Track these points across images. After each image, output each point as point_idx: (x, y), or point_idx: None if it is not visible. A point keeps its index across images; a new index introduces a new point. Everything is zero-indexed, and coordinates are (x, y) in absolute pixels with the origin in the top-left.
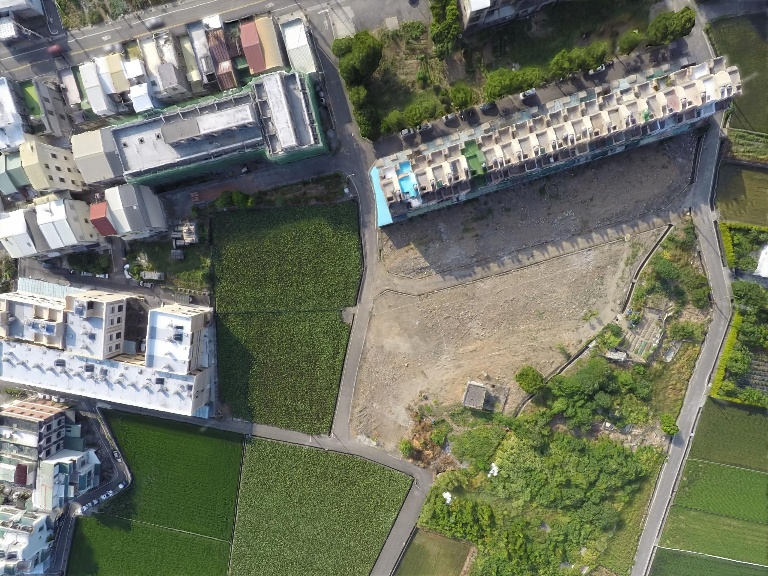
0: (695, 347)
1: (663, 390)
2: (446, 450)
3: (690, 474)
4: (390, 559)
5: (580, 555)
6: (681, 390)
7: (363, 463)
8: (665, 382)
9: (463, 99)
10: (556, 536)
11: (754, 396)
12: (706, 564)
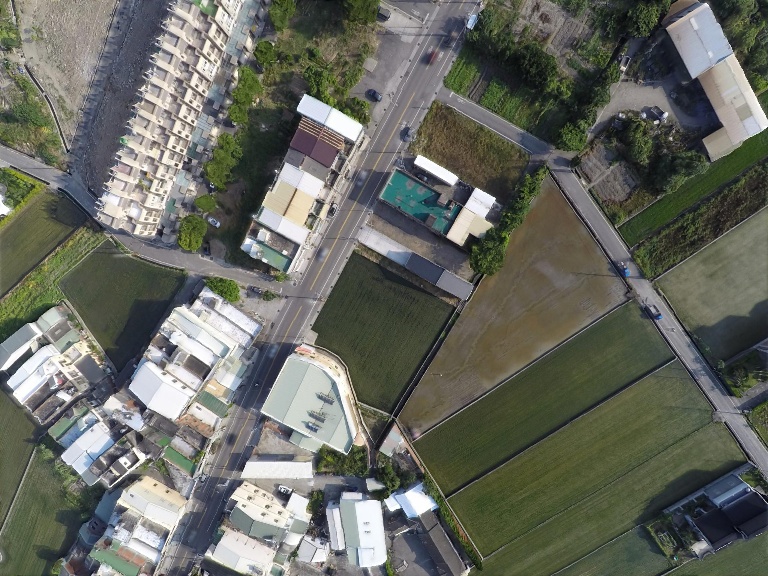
0: None
1: None
2: None
3: None
4: None
5: None
6: None
7: None
8: None
9: (258, 46)
10: None
11: None
12: None
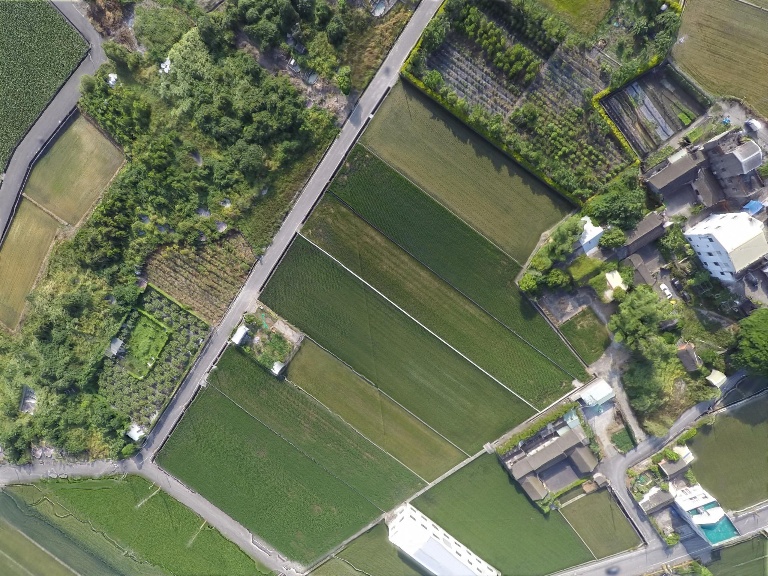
0: (407, 12)
1: (361, 50)
2: (129, 23)
3: (354, 161)
4: (41, 134)
5: (222, 208)
6: (378, 58)
7: (45, 4)
8: (365, 41)
9: None
10: (202, 169)
11: (434, 77)
12: (338, 275)
